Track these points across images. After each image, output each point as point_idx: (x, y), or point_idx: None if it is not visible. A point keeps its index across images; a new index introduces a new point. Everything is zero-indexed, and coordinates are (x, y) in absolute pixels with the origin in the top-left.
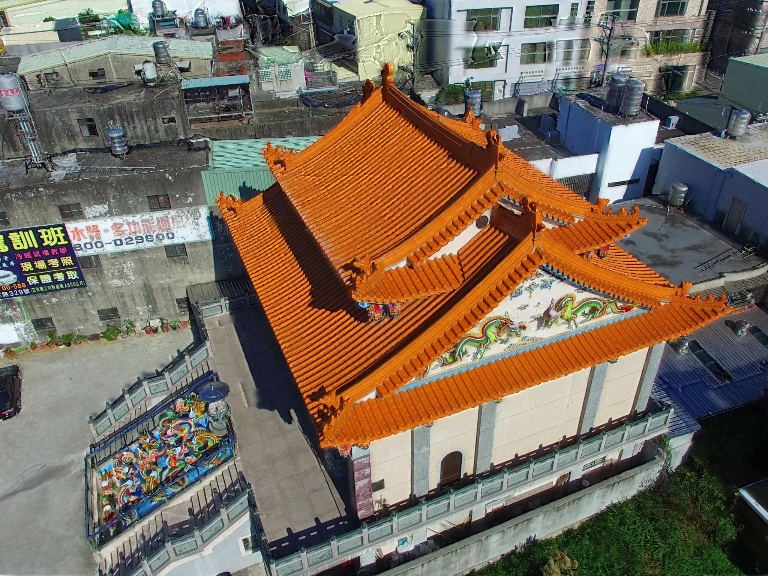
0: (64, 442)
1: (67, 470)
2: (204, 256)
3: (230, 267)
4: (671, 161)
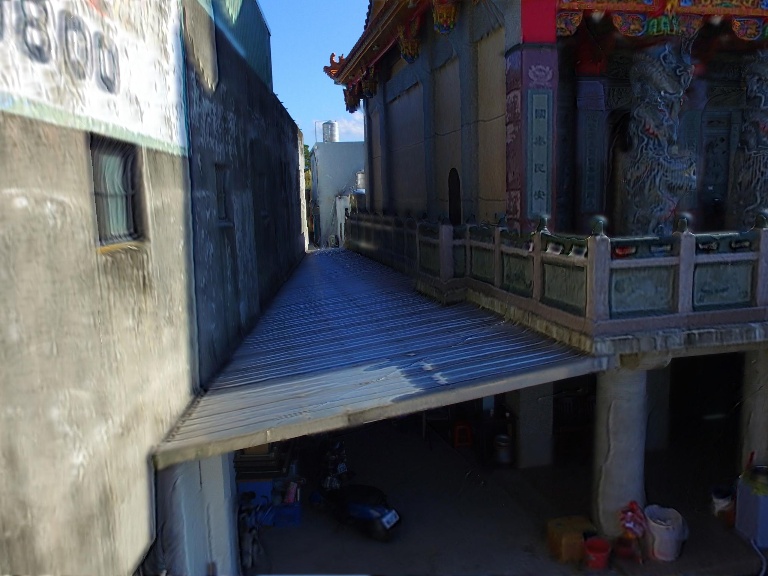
0: None
1: None
2: (176, 246)
3: (210, 310)
4: (332, 160)
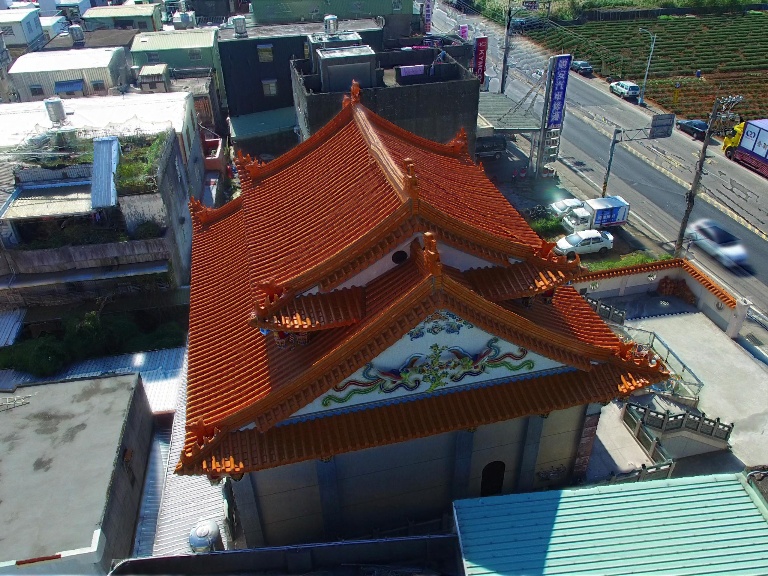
0: (765, 454)
1: (735, 426)
2: None
3: None
4: None
